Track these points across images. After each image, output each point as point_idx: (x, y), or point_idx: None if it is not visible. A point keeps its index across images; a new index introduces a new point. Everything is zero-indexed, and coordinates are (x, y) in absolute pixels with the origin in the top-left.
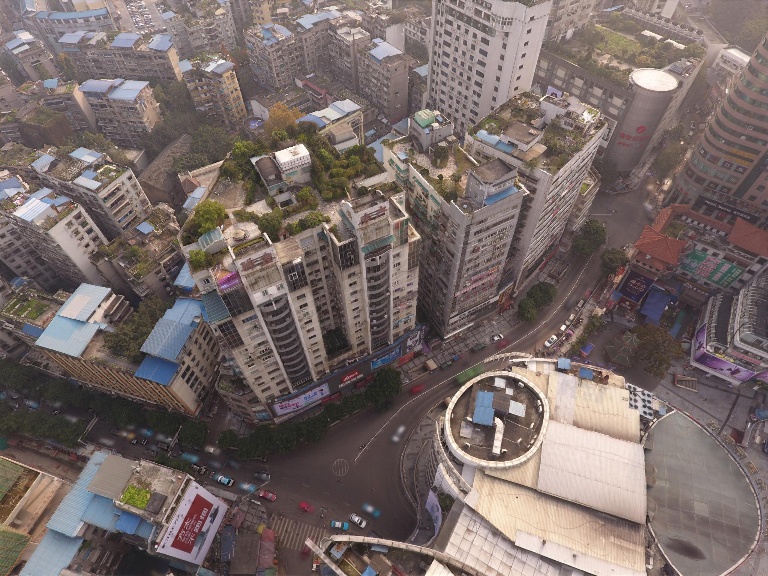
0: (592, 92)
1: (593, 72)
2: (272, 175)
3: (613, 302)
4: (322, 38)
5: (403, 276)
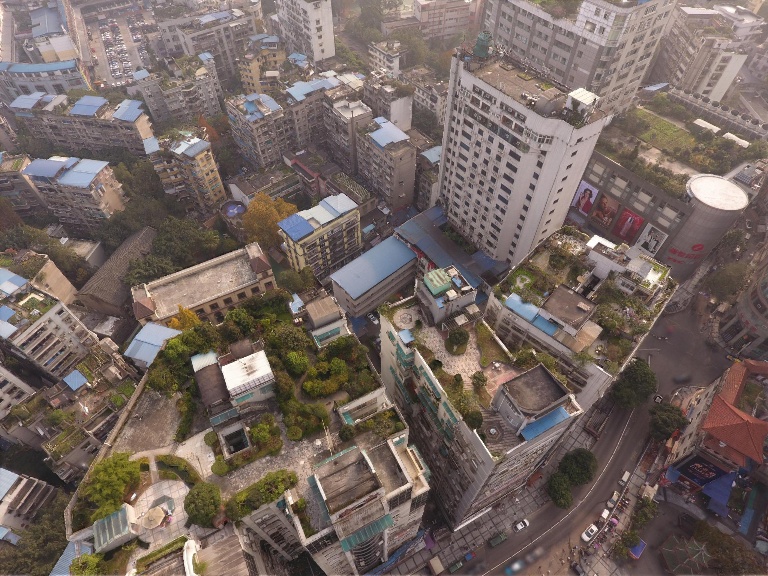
0: (637, 197)
1: (640, 176)
2: (217, 400)
3: (669, 481)
4: (316, 108)
5: (403, 518)
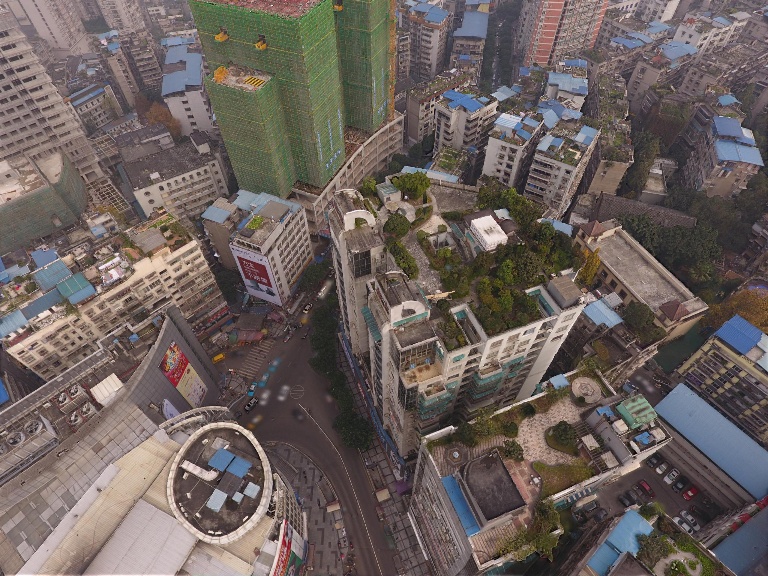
0: None
1: None
2: None
3: None
4: None
5: None
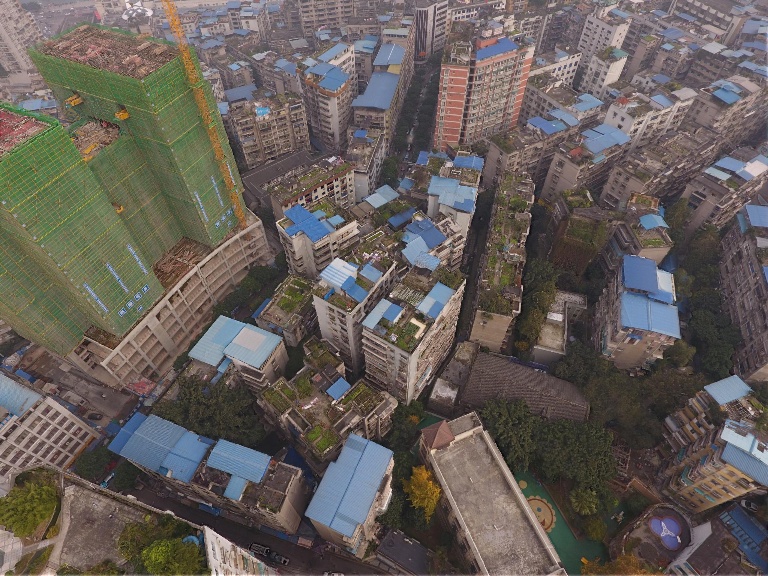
0: None
1: None
2: None
3: None
4: None
5: None
